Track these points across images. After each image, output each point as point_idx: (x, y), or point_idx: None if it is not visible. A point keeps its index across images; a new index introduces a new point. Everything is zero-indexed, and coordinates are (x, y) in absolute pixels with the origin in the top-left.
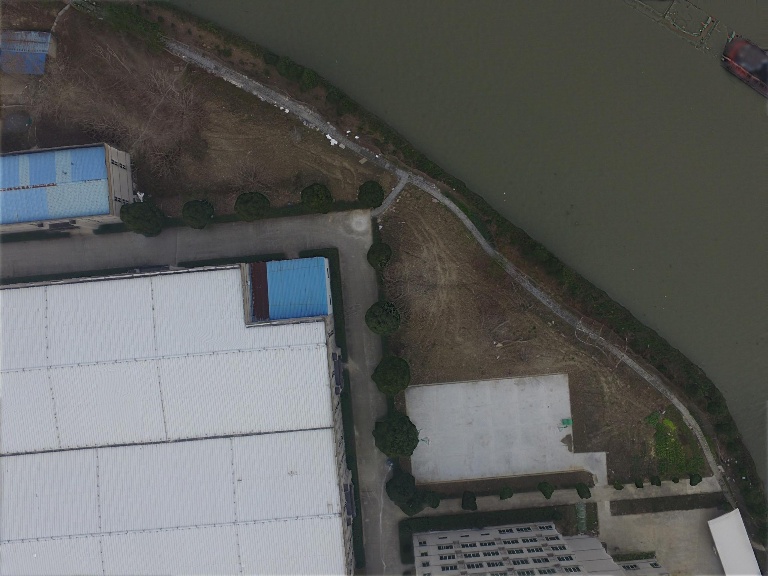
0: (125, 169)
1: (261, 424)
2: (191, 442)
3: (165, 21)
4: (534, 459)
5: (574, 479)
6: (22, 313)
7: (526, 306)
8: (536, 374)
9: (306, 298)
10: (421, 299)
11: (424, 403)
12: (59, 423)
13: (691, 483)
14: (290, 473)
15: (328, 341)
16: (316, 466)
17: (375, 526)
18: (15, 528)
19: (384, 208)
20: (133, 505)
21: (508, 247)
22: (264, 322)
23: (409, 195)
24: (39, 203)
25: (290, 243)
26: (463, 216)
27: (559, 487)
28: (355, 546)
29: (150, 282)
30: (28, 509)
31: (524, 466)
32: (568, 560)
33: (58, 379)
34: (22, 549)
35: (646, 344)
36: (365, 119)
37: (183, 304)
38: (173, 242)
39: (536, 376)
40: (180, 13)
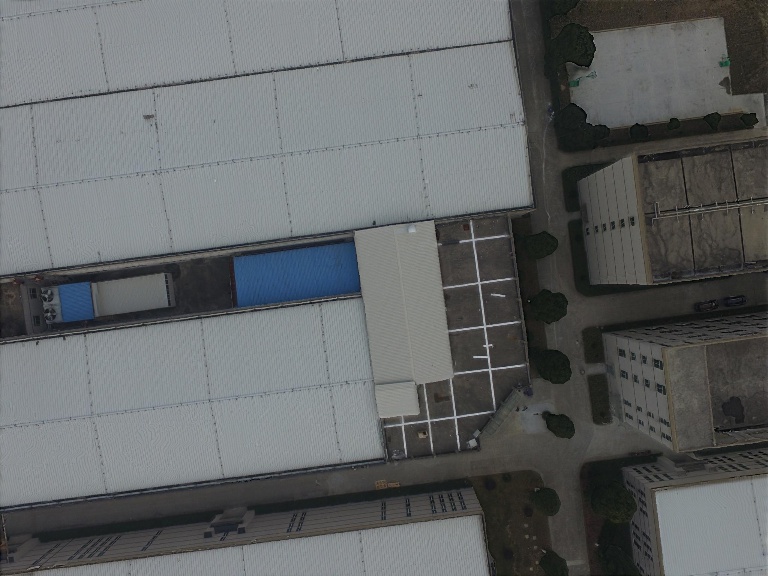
0: None
1: (439, 39)
2: (368, 61)
3: None
4: (693, 103)
5: (733, 121)
6: None
7: None
8: (692, 18)
9: None
10: None
11: None
12: (234, 47)
13: None
14: (470, 86)
15: None
16: (496, 78)
17: (538, 177)
18: (194, 153)
19: None
20: (313, 125)
21: None
22: None
23: None
24: None
25: None
26: None
27: (719, 130)
28: None
29: None
30: (206, 134)
31: (684, 110)
32: None
33: (232, 0)
34: (202, 174)
35: None
36: None
37: None
38: None
39: (692, 20)
40: None
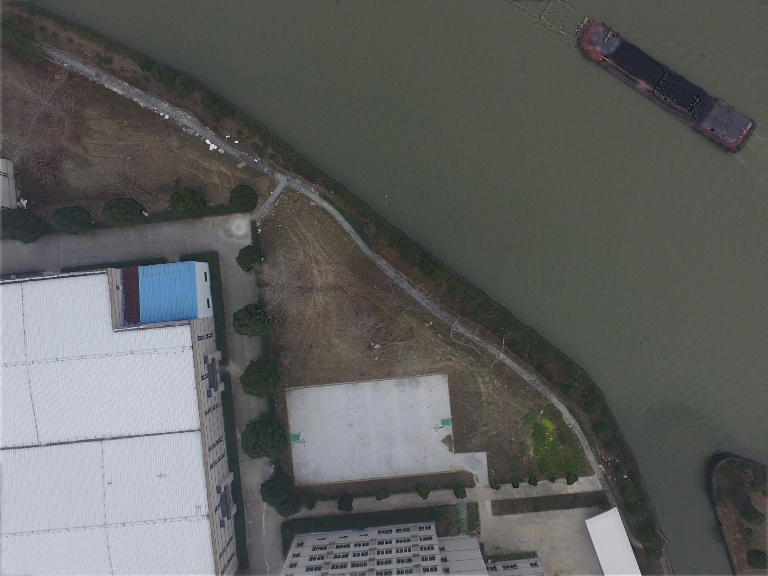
0: (6, 176)
1: (131, 427)
2: (62, 446)
3: (47, 30)
4: (415, 460)
5: (455, 479)
6: None
7: (404, 307)
8: (416, 375)
9: (176, 302)
10: (297, 301)
11: (305, 405)
12: None
13: (567, 482)
14: (159, 476)
15: (195, 344)
16: (185, 468)
17: (258, 528)
18: None
19: (263, 212)
20: (5, 509)
21: (387, 249)
22: (131, 326)
23: (287, 198)
24: None
25: (171, 247)
26: (341, 218)
27: (440, 487)
28: (238, 548)
29: (21, 288)
30: None
31: (405, 467)
32: (430, 560)
33: None
34: None
35: (525, 344)
36: (243, 124)
37: (57, 309)
38: (56, 248)
39: (416, 377)
40: (61, 22)
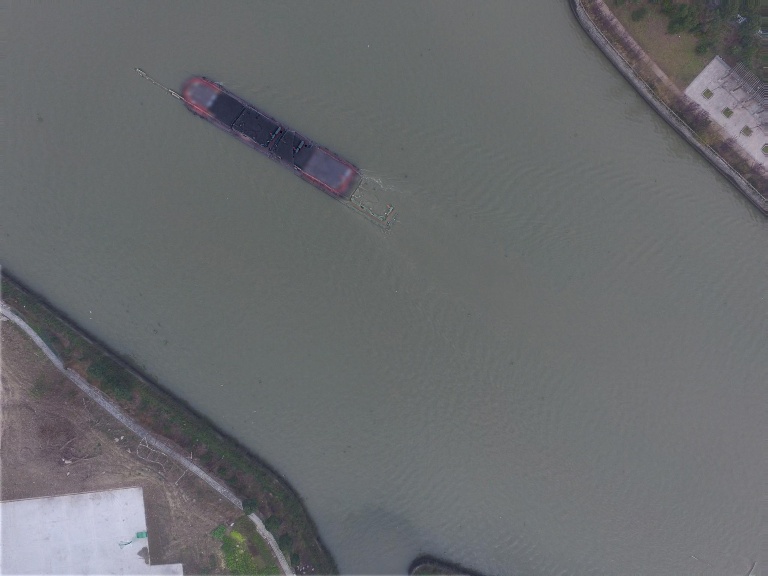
0: None
1: None
2: None
3: None
4: (111, 572)
5: None
6: None
7: (94, 422)
8: (111, 488)
9: None
10: None
11: (1, 520)
12: None
13: None
14: None
15: None
16: None
17: None
18: None
19: None
20: None
21: (81, 362)
22: None
23: None
24: None
25: None
26: (33, 333)
27: None
28: None
29: None
30: None
31: None
32: None
33: None
34: None
35: (220, 455)
36: None
37: None
38: None
39: (111, 490)
40: None
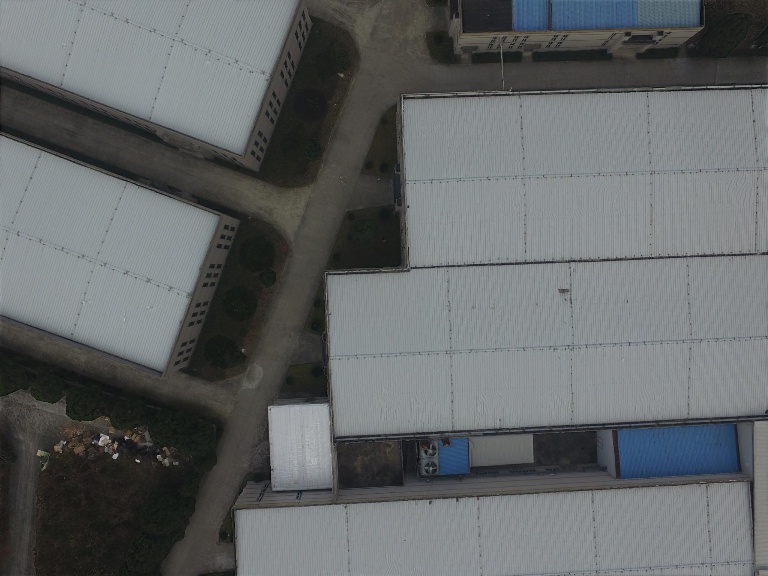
0: None
1: None
2: None
3: None
4: None
5: None
6: (624, 117)
7: None
8: None
9: None
10: None
11: None
12: (653, 230)
13: None
14: None
15: None
16: None
17: None
18: (607, 332)
19: None
20: (723, 314)
21: None
22: None
23: None
24: (629, 11)
25: None
26: None
27: None
28: None
29: (750, 94)
30: (619, 314)
31: None
32: None
33: (659, 185)
34: (613, 353)
35: None
36: None
37: None
38: (713, 72)
39: None
40: None
